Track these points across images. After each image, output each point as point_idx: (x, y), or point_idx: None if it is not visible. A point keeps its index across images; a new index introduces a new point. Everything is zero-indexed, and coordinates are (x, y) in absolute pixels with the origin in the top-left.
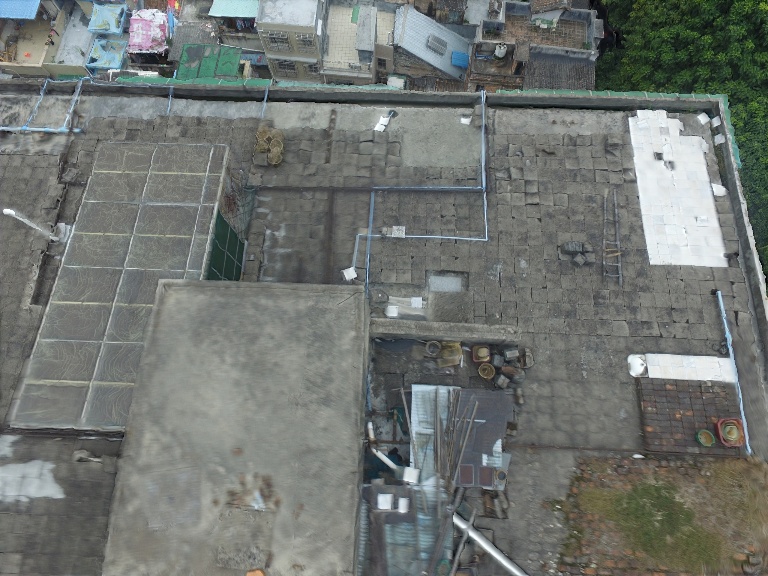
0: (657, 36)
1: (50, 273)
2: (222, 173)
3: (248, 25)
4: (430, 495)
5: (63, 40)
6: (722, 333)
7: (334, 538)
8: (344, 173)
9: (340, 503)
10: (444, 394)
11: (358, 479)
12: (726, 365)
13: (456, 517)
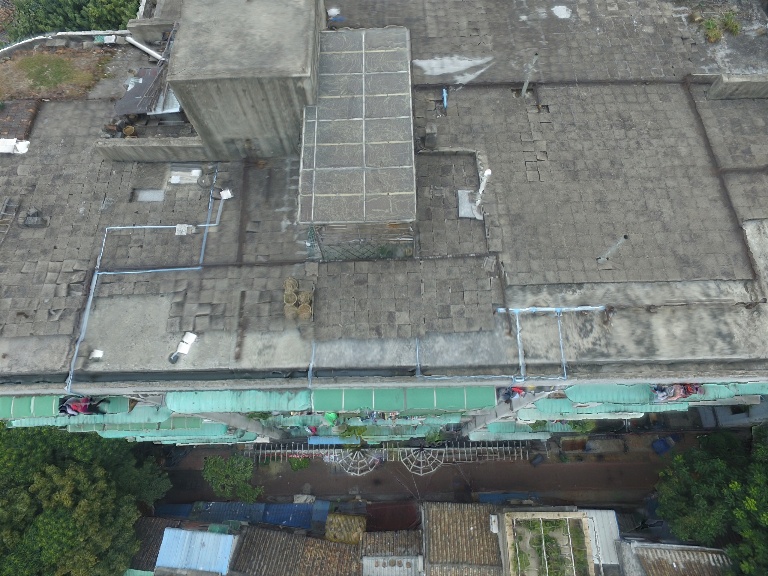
0: None
1: (473, 180)
2: (300, 196)
3: None
4: None
5: None
6: None
7: None
8: (227, 282)
9: None
10: (158, 109)
11: None
12: None
13: None
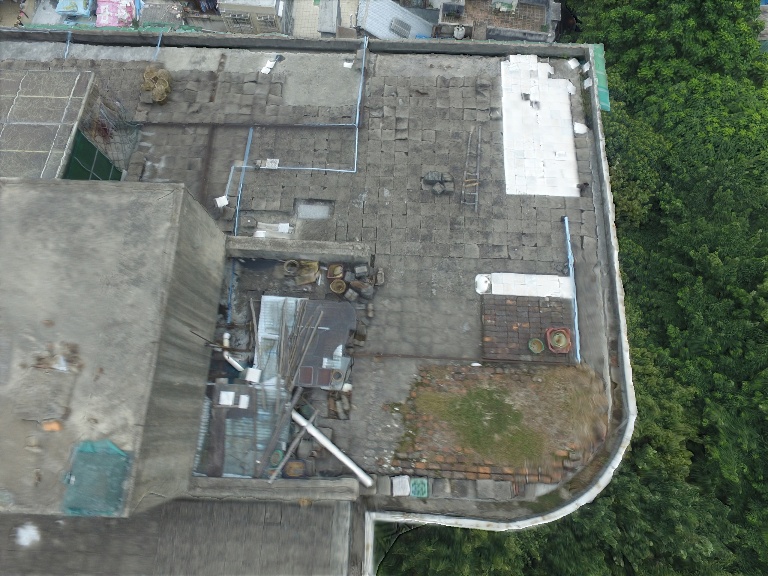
0: (608, 17)
1: None
2: (85, 96)
3: (212, 7)
4: (270, 393)
5: (33, 22)
6: (566, 255)
7: (127, 397)
8: (226, 111)
9: (137, 368)
10: (292, 304)
11: (157, 349)
12: (566, 283)
13: (297, 416)
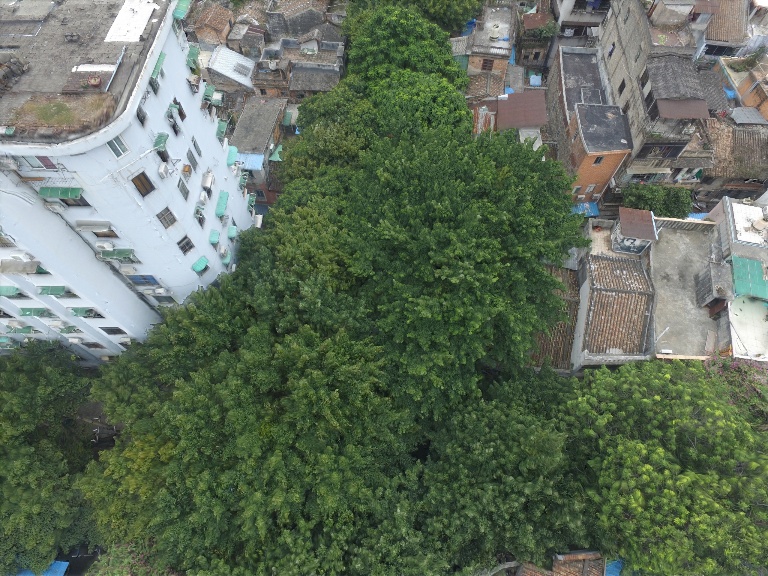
0: None
1: None
2: None
3: None
4: None
5: None
6: None
7: None
8: None
9: None
10: None
11: None
12: None
13: None
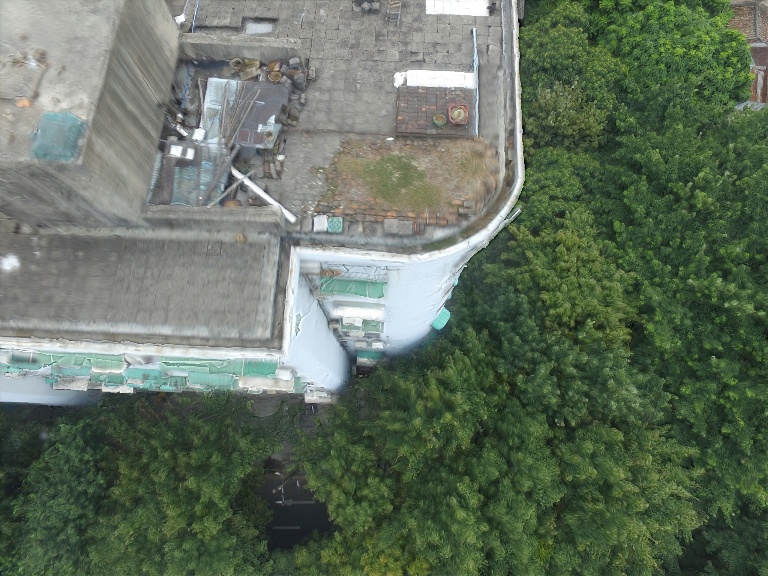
0: None
1: None
2: None
3: None
4: (212, 149)
5: None
6: (472, 58)
7: (83, 85)
8: None
9: (92, 67)
10: (234, 84)
11: (109, 56)
12: (470, 77)
13: (236, 172)
